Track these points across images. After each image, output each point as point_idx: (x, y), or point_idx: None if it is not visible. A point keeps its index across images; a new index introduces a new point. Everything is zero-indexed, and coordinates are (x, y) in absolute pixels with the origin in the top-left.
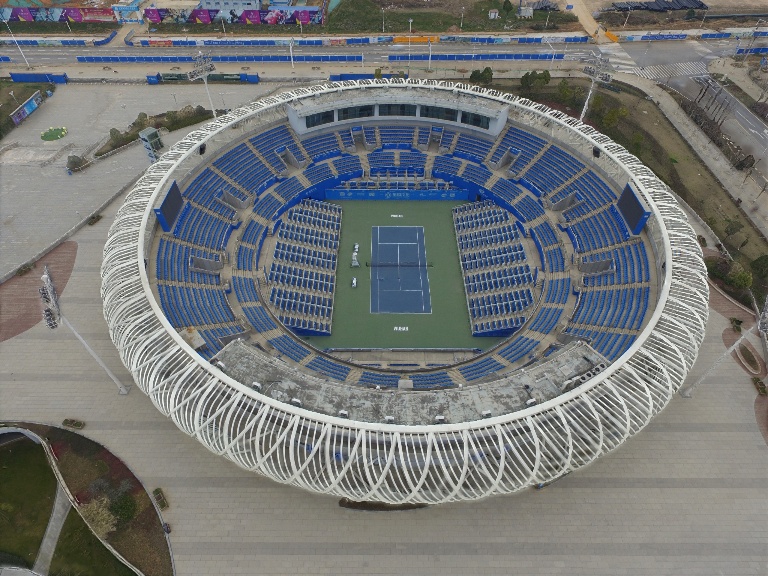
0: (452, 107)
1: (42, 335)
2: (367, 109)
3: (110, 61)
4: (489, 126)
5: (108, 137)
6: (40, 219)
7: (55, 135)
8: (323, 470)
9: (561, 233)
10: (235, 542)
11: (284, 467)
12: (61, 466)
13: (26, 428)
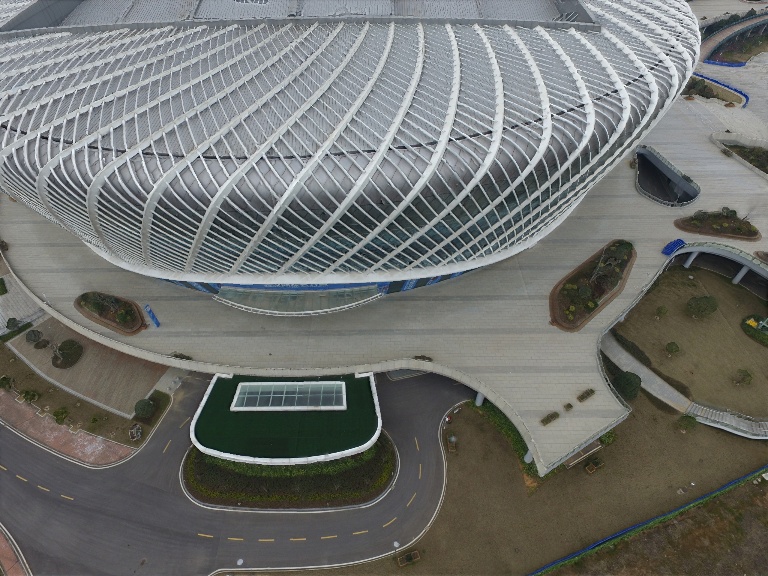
0: None
1: None
2: None
3: None
4: None
5: None
6: None
7: None
8: None
9: None
10: None
11: None
12: None
13: None
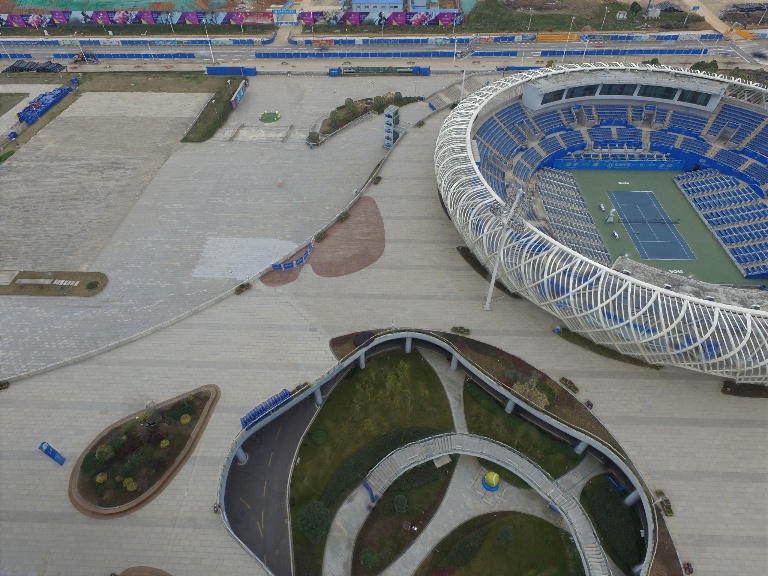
0: (673, 86)
1: (390, 266)
2: (590, 89)
3: (284, 57)
4: (708, 103)
5: (322, 119)
6: (307, 183)
7: (271, 118)
8: (761, 346)
9: None
10: (650, 417)
11: (723, 345)
12: (469, 360)
13: (423, 333)
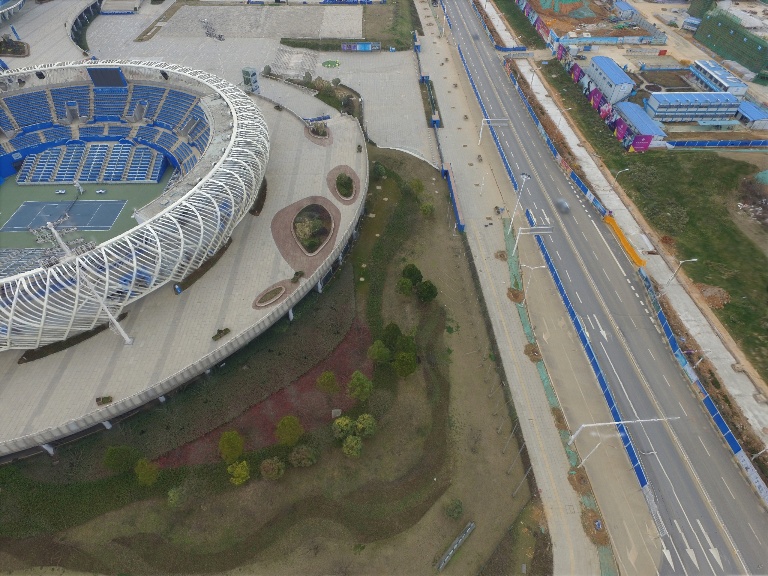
0: None
1: None
2: None
3: None
4: None
5: None
6: None
7: (330, 64)
8: None
9: None
10: None
11: None
12: None
13: None
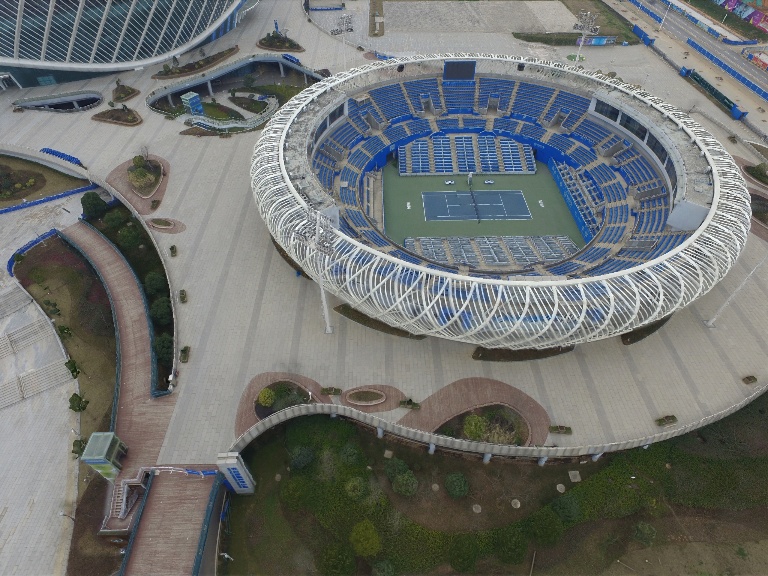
0: (677, 172)
1: None
2: None
3: (701, 52)
4: None
5: None
6: None
7: None
8: None
9: None
10: None
11: None
12: None
13: None
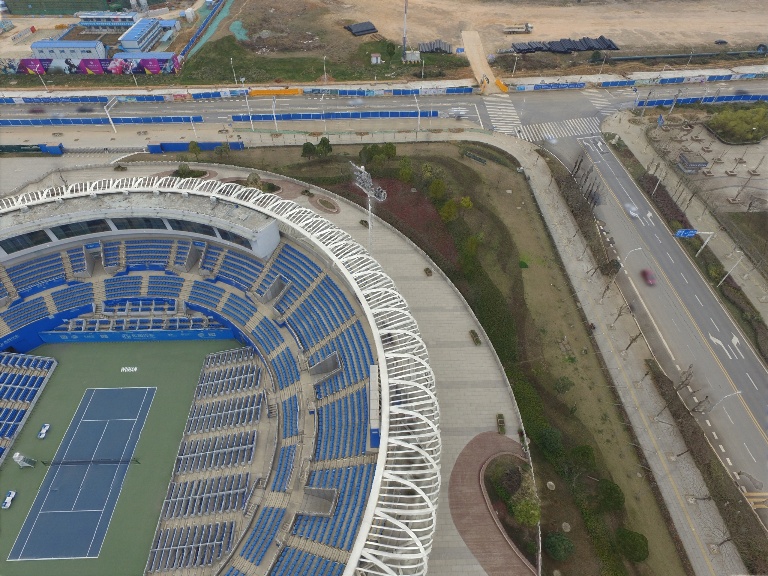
0: (203, 222)
1: None
2: (99, 223)
3: None
4: (251, 247)
5: None
6: None
7: None
8: None
9: (307, 417)
10: None
11: None
12: None
13: None
